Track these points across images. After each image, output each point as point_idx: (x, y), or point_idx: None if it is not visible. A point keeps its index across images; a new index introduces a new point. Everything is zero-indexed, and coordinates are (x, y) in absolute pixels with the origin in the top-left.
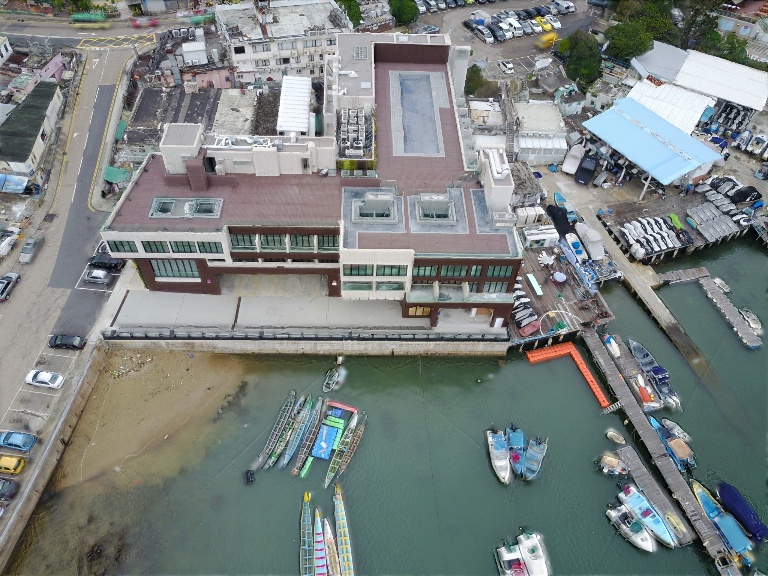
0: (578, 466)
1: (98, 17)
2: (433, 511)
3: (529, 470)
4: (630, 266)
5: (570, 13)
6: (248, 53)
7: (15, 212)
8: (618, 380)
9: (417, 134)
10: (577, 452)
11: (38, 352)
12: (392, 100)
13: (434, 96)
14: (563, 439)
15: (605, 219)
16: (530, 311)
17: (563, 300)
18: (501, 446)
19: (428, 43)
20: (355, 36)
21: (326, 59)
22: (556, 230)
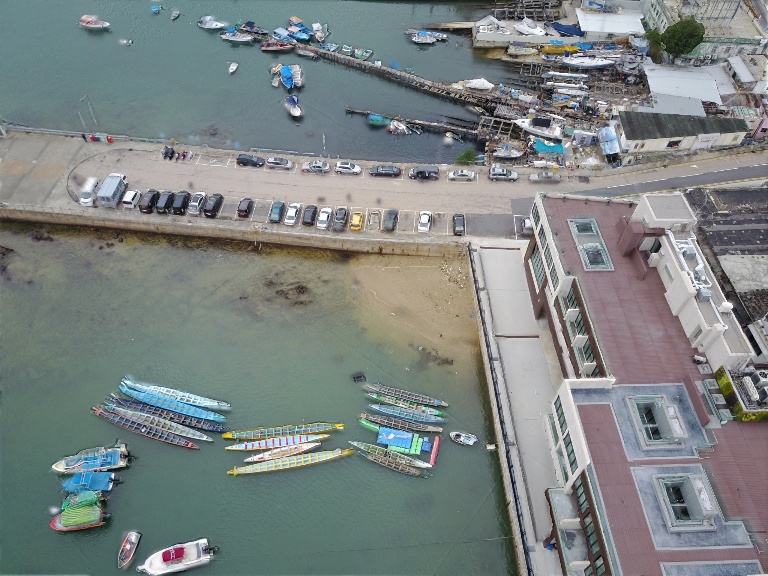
0: None
1: None
2: (325, 548)
3: None
4: None
5: None
6: None
7: (587, 160)
8: None
9: None
10: None
11: (449, 211)
12: None
13: None
14: None
15: None
16: None
17: None
18: None
19: None
20: None
21: None
22: None
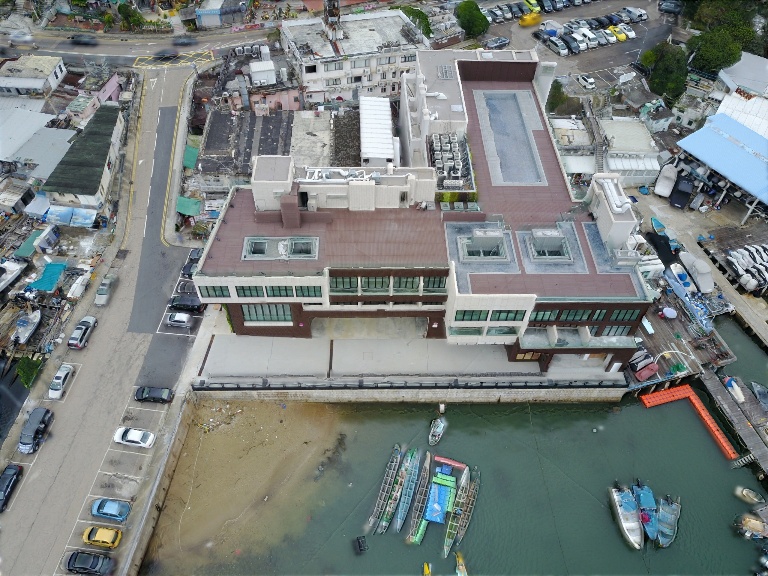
0: (715, 528)
1: (151, 33)
2: None
3: (664, 534)
4: (741, 299)
5: (642, 21)
6: (319, 72)
7: (83, 247)
8: (748, 429)
9: (512, 160)
10: (712, 512)
11: (124, 406)
12: (481, 123)
13: (525, 117)
14: (695, 497)
15: (708, 246)
16: (645, 352)
17: (684, 342)
18: (633, 508)
19: (514, 60)
20: (436, 53)
21: (404, 78)
22: (660, 260)
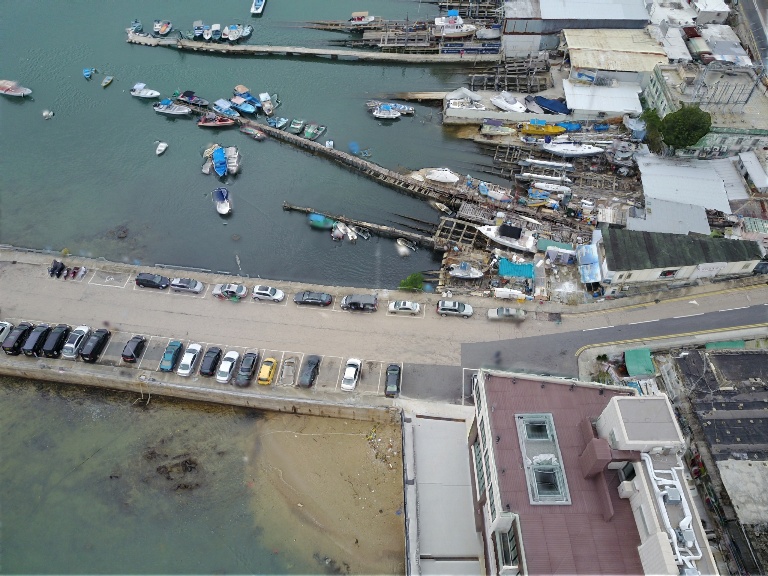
0: None
1: None
2: None
3: None
4: None
5: None
6: None
7: (562, 286)
8: None
9: None
10: None
11: (383, 360)
12: None
13: None
14: None
15: None
16: None
17: None
18: None
19: None
20: None
21: None
22: None
